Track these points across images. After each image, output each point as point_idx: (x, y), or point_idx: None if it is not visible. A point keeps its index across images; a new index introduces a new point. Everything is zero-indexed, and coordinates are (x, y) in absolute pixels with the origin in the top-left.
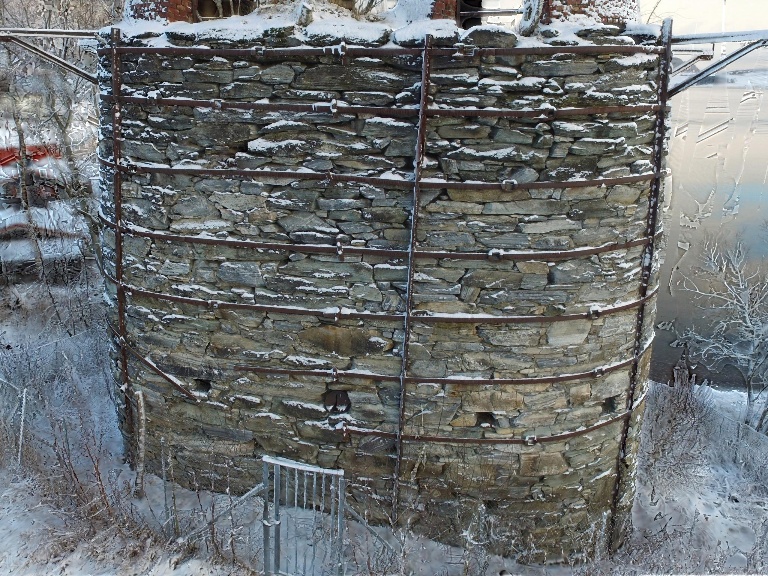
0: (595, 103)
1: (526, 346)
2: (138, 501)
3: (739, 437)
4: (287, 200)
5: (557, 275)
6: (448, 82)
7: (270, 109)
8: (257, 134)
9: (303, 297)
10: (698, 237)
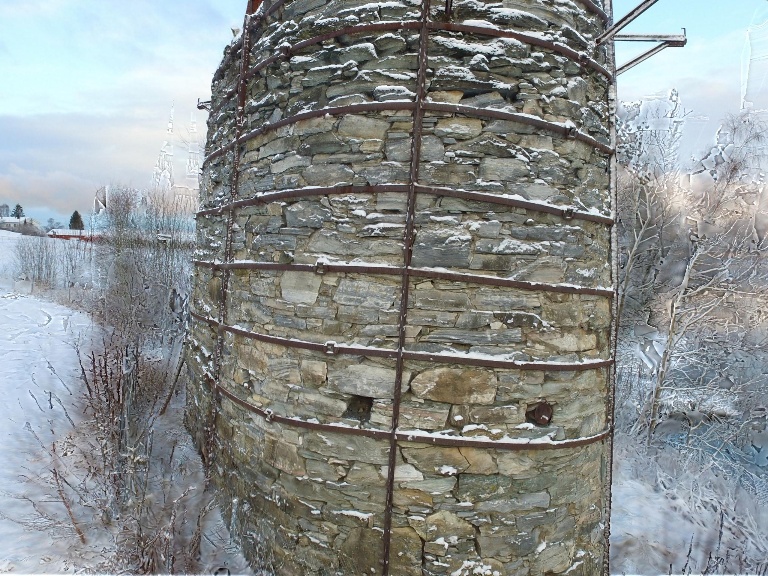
0: (323, 31)
1: None
2: (158, 416)
3: None
4: None
5: (287, 216)
6: (256, 50)
7: None
8: None
9: None
10: None
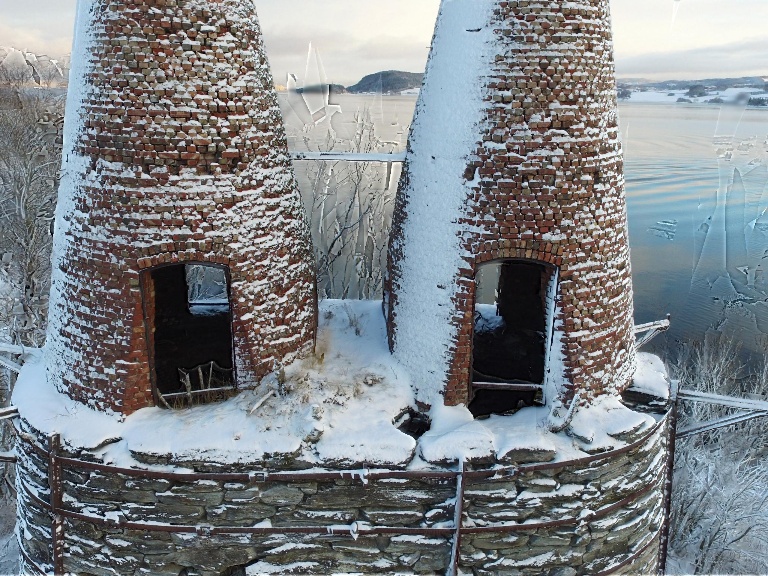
0: (627, 493)
1: None
2: None
3: None
4: None
5: None
6: None
7: (273, 532)
8: (256, 555)
9: None
10: None
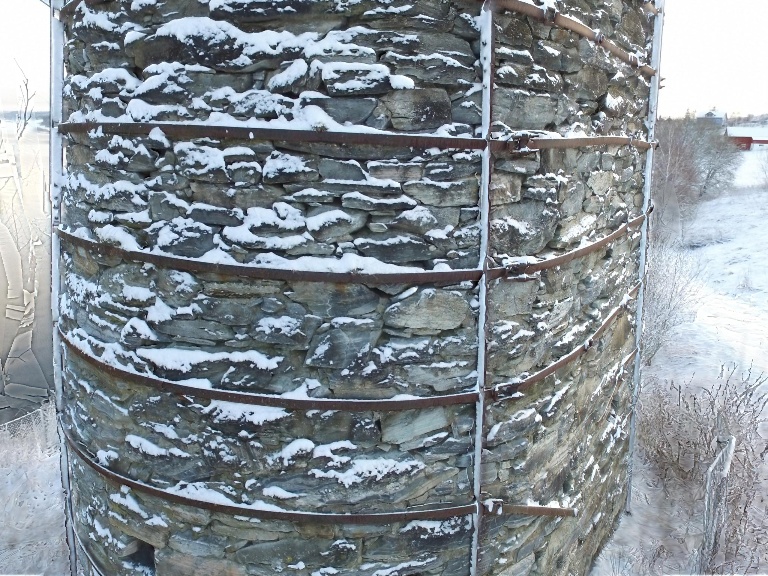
0: None
1: None
2: None
3: None
4: None
5: None
6: None
7: None
8: None
9: None
10: None
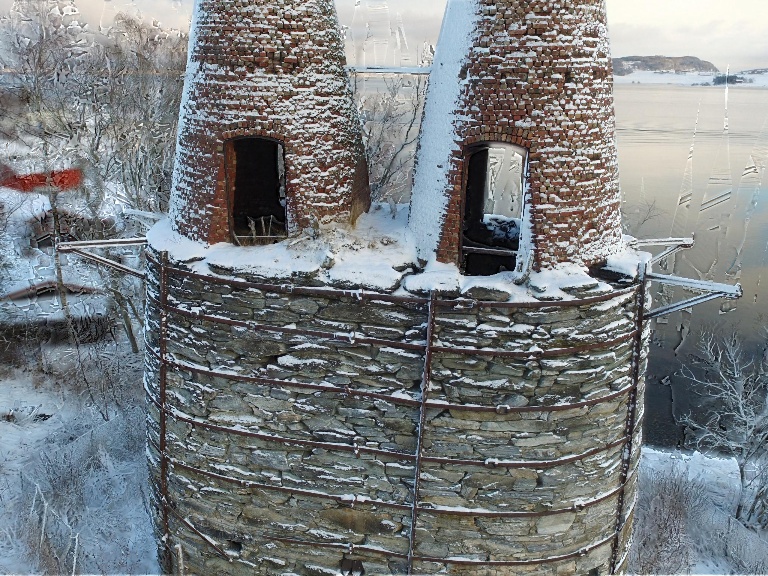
0: (578, 343)
1: (518, 535)
2: None
3: (730, 530)
4: (311, 406)
5: (545, 480)
6: (450, 325)
7: (297, 333)
8: (286, 351)
9: (324, 484)
10: (695, 327)
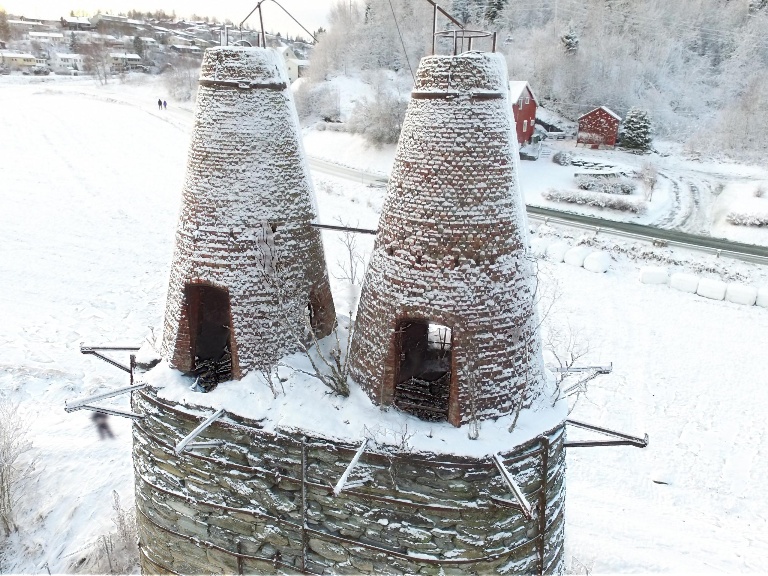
0: None
1: None
2: None
3: None
4: None
5: None
6: None
7: None
8: None
9: None
10: None
